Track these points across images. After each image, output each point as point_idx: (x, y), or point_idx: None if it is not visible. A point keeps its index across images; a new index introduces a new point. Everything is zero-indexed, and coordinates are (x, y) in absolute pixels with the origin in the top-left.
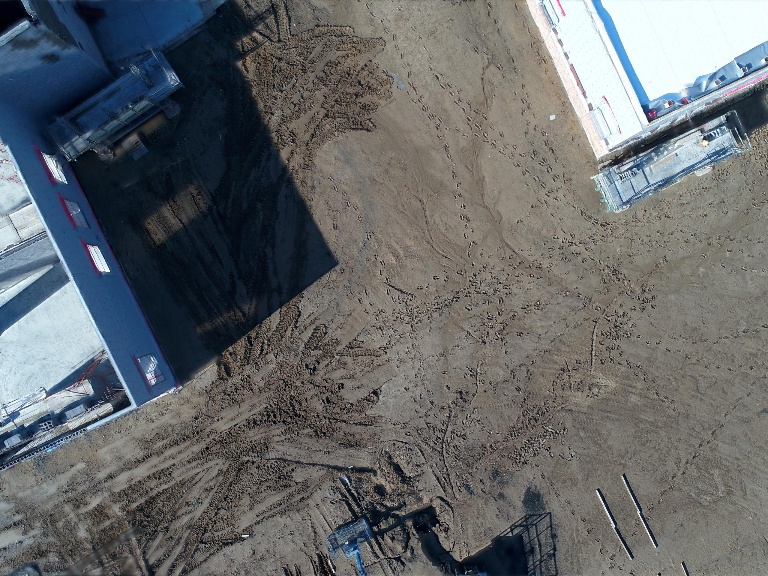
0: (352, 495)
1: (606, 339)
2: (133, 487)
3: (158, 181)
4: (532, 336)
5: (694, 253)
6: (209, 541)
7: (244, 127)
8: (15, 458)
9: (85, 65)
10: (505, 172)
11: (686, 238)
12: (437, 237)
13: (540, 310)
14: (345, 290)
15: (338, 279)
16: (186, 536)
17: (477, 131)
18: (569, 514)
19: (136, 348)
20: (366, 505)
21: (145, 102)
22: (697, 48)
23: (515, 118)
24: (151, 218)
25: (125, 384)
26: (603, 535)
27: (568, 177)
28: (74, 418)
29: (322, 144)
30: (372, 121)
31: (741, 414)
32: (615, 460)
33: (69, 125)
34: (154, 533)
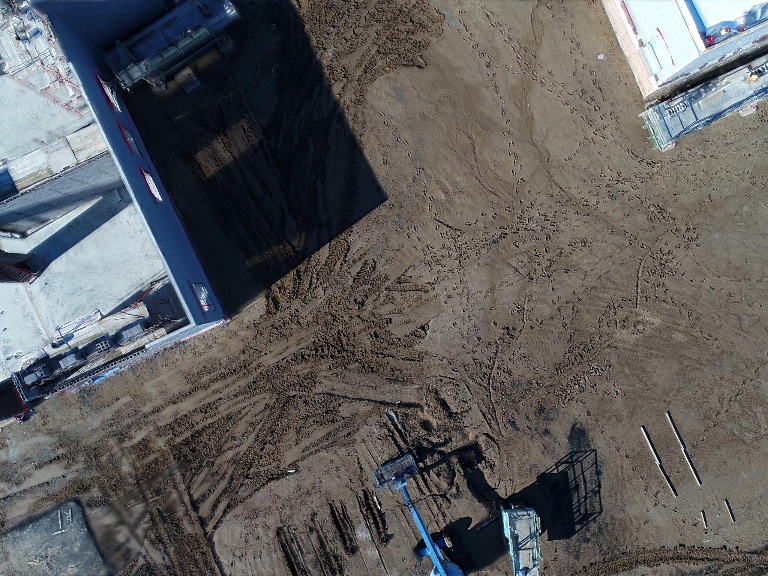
0: (399, 431)
1: (651, 277)
2: (179, 421)
3: (209, 114)
4: (579, 273)
5: (738, 193)
6: (255, 476)
7: (296, 61)
8: (66, 383)
9: None
10: (553, 110)
11: (730, 178)
12: (486, 174)
13: (587, 247)
14: (394, 225)
15: (387, 214)
16: (232, 471)
17: (526, 69)
18: (614, 451)
19: (190, 274)
20: (412, 441)
21: (202, 29)
22: None
23: (564, 57)
24: (202, 150)
25: (184, 302)
26: (647, 472)
27: (615, 116)
28: (127, 342)
29: (373, 79)
30: (423, 58)
31: None
32: (660, 397)
33: None
34: (199, 468)
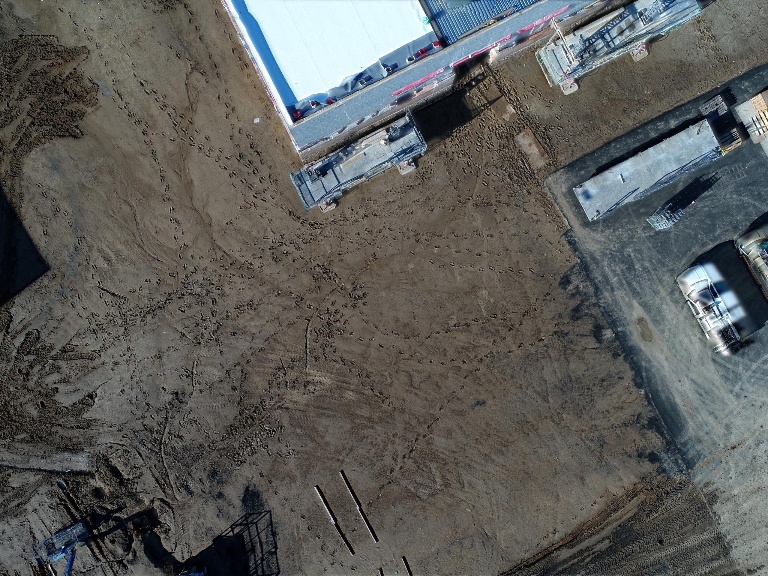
0: (70, 499)
1: (320, 337)
2: None
3: None
4: (246, 336)
5: (403, 250)
6: None
7: None
8: None
9: None
10: (212, 175)
11: (394, 235)
12: (148, 240)
13: (253, 310)
14: (57, 295)
15: (50, 284)
16: None
17: (183, 135)
18: (289, 512)
19: None
20: (85, 508)
21: None
22: (342, 50)
23: (220, 122)
24: None
25: None
26: (324, 532)
27: (274, 178)
28: None
29: (29, 151)
30: (79, 128)
31: (456, 407)
32: (333, 456)
33: None
34: None
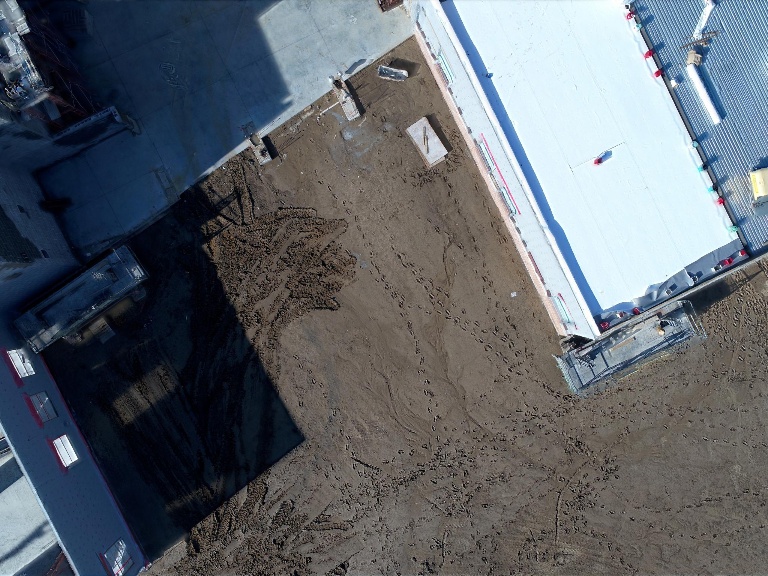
0: None
1: (570, 509)
2: None
3: (125, 362)
4: (497, 507)
5: (656, 424)
6: None
7: (210, 308)
8: None
9: (49, 268)
10: (468, 348)
11: (648, 409)
12: (402, 412)
13: (505, 482)
14: (311, 465)
15: (304, 455)
16: None
17: (439, 308)
18: None
19: (103, 542)
20: None
21: (109, 300)
22: (648, 258)
23: (477, 295)
24: (119, 398)
25: None
26: None
27: (530, 352)
28: None
29: (287, 323)
30: (336, 300)
31: None
32: None
33: (34, 326)
34: None
